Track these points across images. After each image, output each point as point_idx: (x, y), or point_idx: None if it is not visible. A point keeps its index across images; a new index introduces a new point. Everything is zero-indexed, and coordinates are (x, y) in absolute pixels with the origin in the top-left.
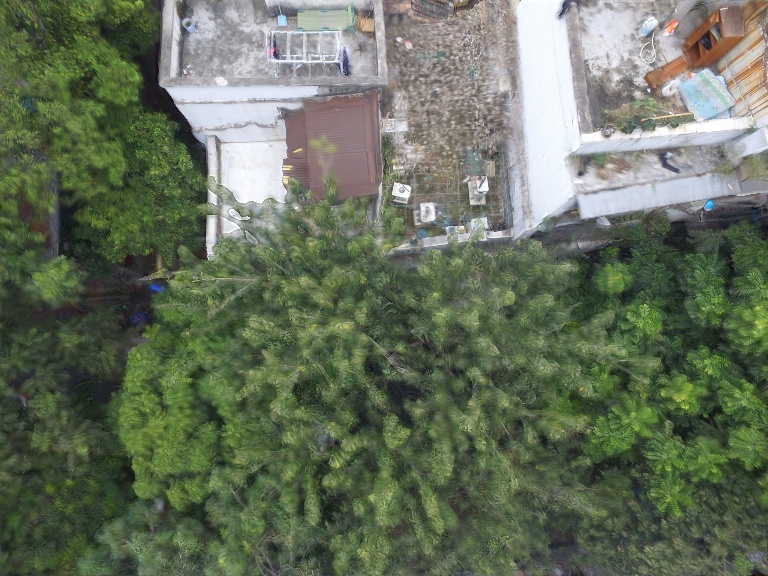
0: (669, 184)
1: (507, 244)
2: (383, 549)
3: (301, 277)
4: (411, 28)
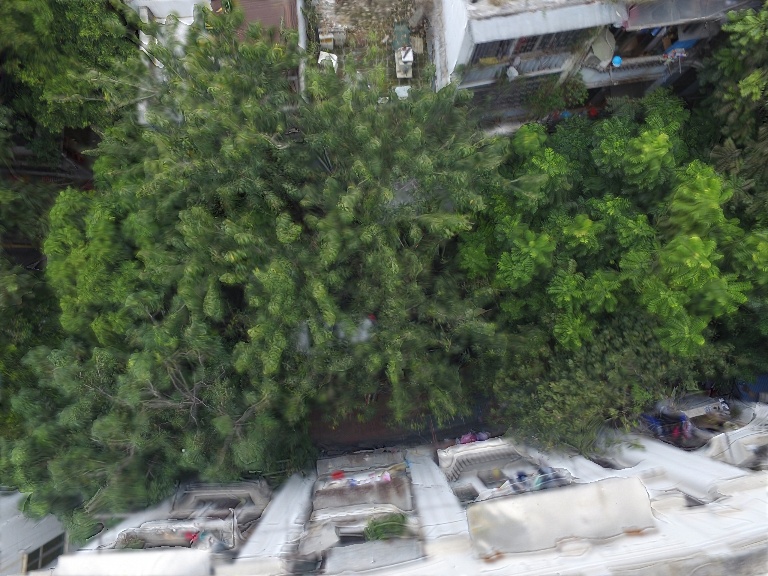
0: (559, 11)
1: None
2: (278, 342)
3: (185, 62)
4: None
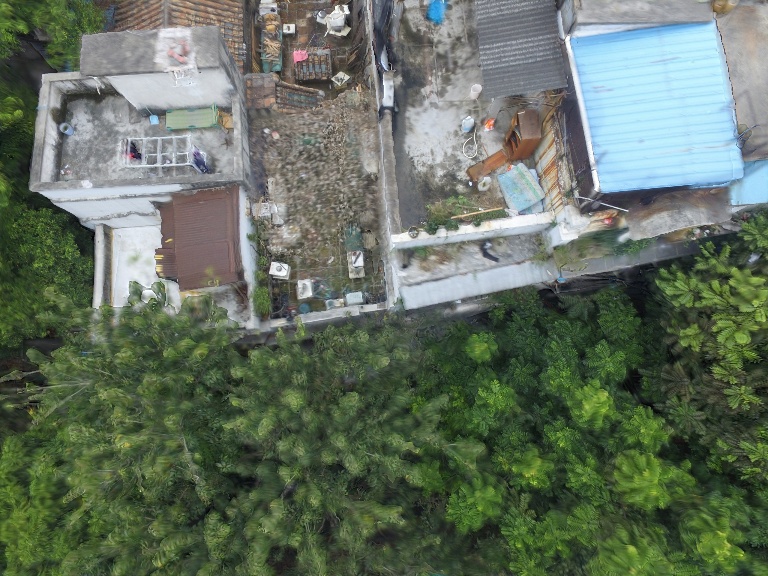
0: (490, 273)
1: (380, 317)
2: None
3: (104, 391)
4: (278, 119)
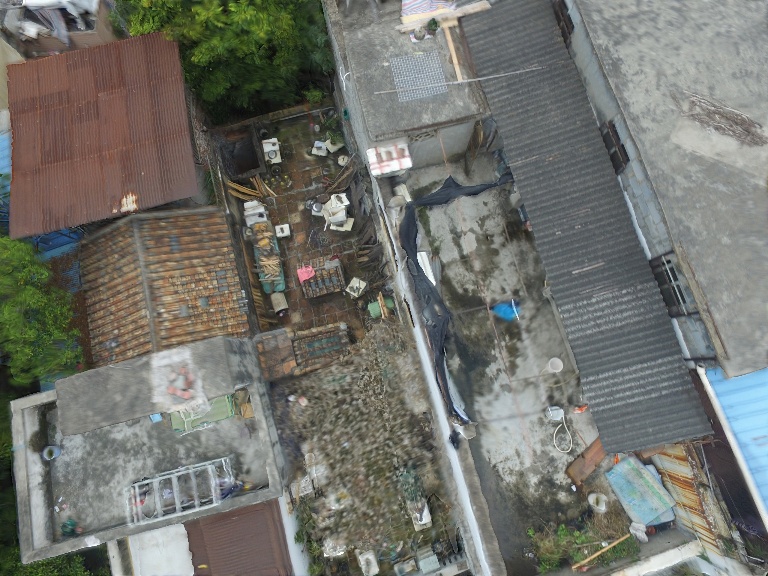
0: None
1: None
2: None
3: None
4: (302, 380)
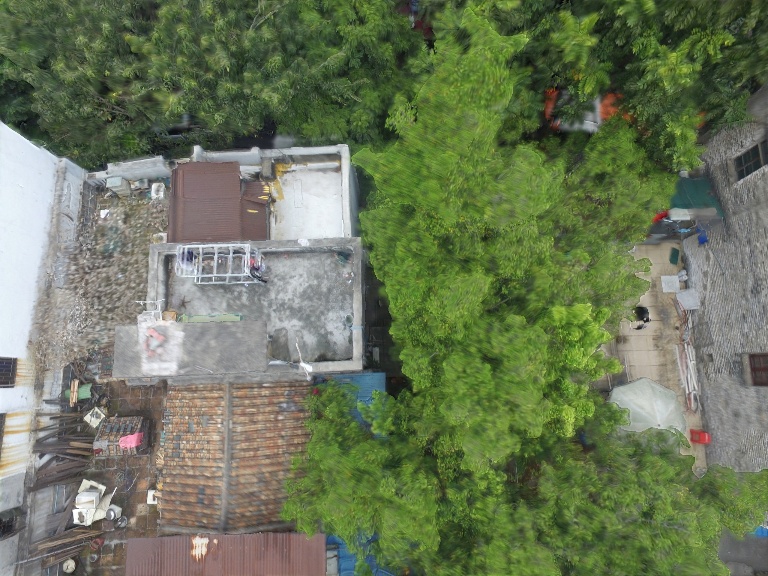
0: None
1: None
2: None
3: None
4: None
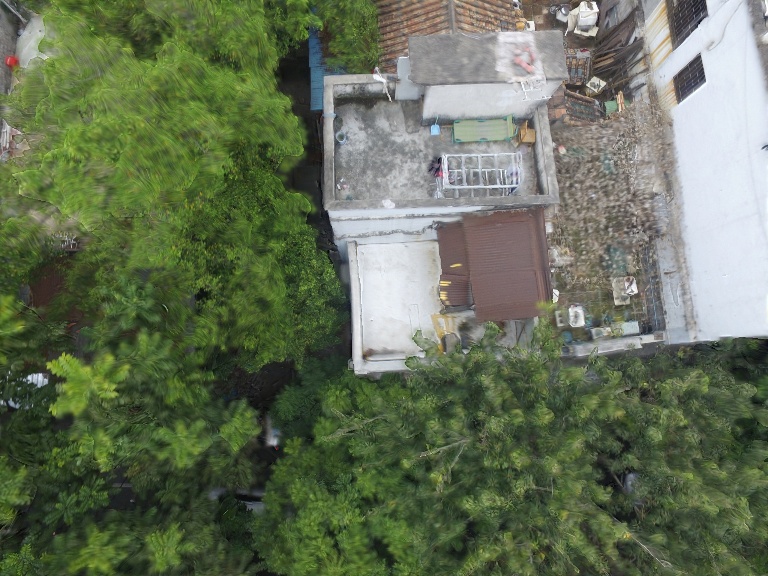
0: None
1: None
2: None
3: (554, 463)
4: (564, 132)
